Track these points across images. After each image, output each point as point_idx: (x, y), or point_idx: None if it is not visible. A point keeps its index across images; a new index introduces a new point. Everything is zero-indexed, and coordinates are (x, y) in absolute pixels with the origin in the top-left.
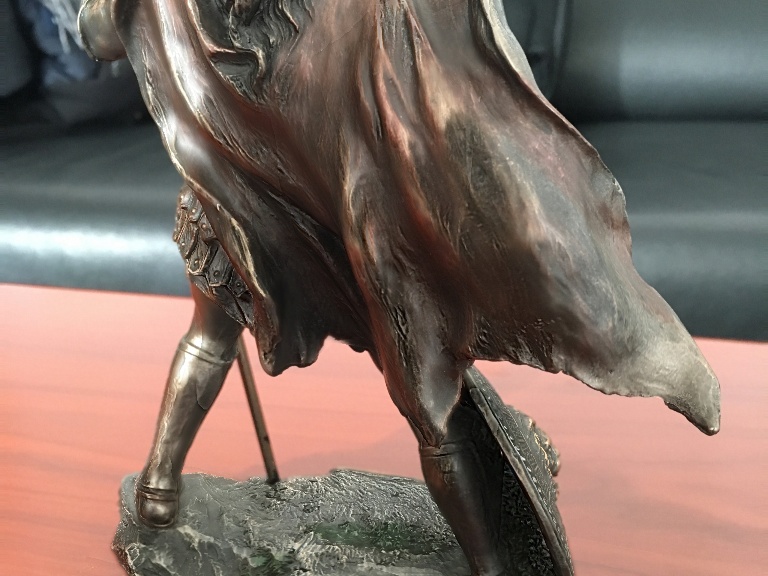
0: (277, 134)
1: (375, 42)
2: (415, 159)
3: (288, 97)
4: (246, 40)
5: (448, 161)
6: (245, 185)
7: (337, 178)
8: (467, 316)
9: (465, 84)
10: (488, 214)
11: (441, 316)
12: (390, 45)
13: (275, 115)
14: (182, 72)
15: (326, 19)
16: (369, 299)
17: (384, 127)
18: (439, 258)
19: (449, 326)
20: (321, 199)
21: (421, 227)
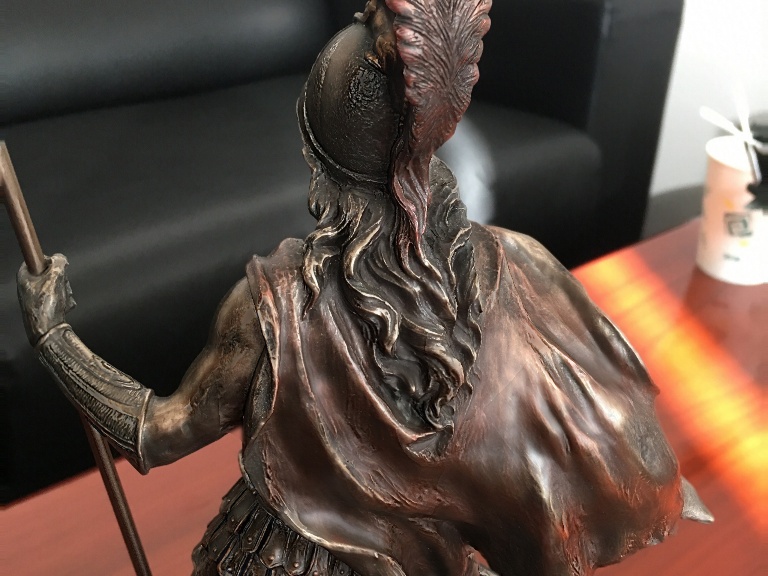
0: (444, 475)
1: (548, 385)
2: (605, 459)
3: (466, 446)
4: (443, 419)
5: (627, 451)
6: (385, 523)
7: (529, 492)
8: (620, 537)
9: (623, 395)
10: (652, 473)
11: (591, 545)
12: (560, 384)
13: (453, 464)
14: (348, 461)
15: (491, 376)
16: (556, 563)
17: (575, 445)
18: (612, 512)
19: (598, 549)
20: (474, 506)
21: (605, 499)
